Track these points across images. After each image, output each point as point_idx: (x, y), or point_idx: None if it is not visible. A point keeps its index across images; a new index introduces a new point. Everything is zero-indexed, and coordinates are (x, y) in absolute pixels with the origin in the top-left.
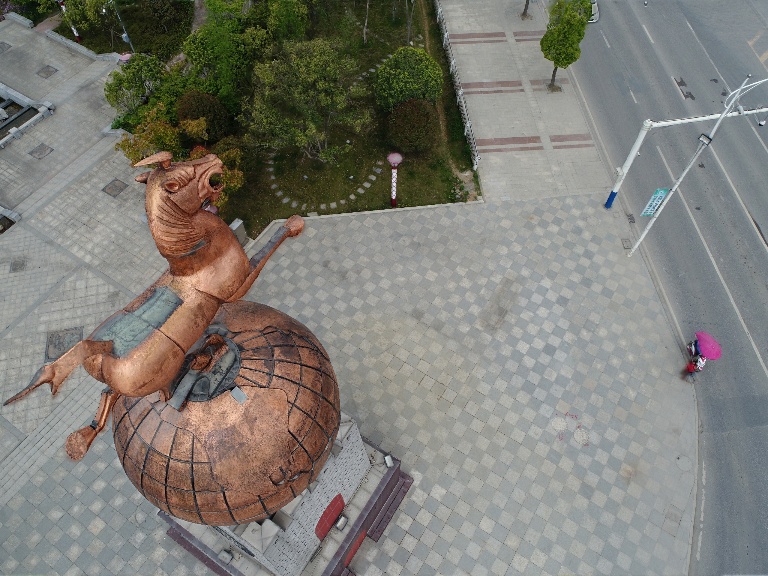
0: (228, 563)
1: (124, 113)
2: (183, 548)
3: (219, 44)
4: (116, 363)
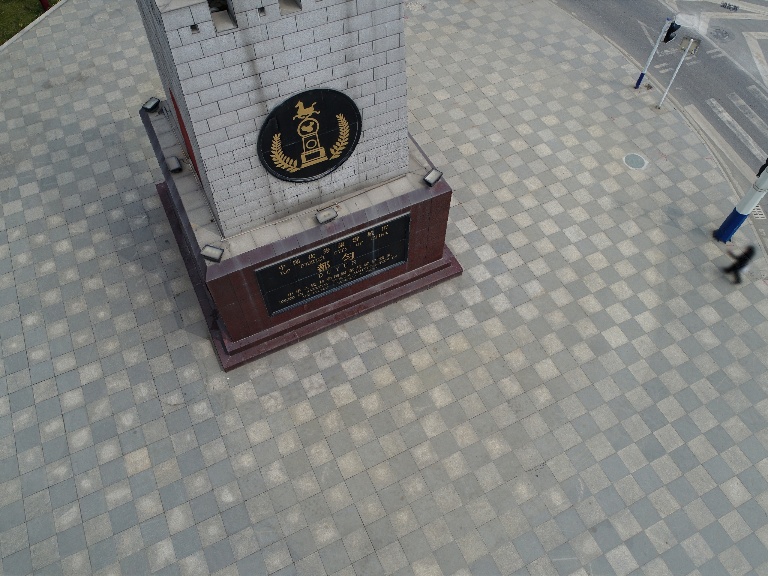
0: (336, 214)
1: None
2: (257, 361)
3: None
4: None
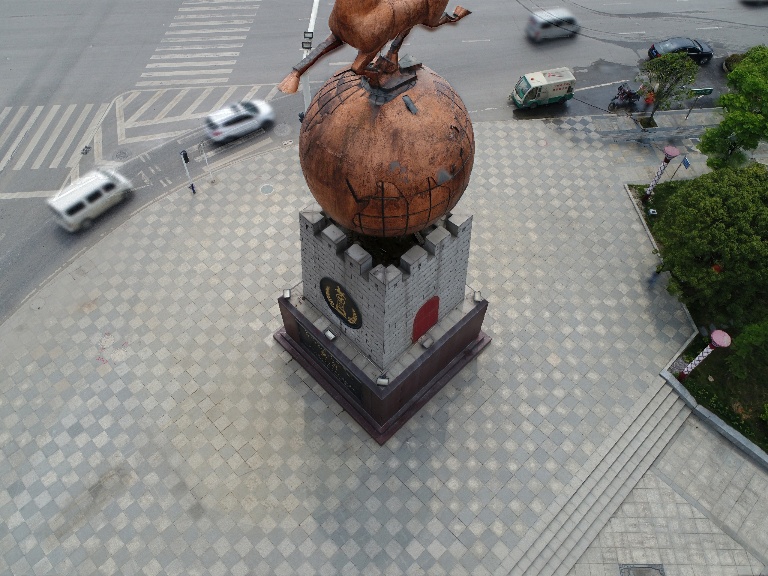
0: None
1: None
2: None
3: None
4: None
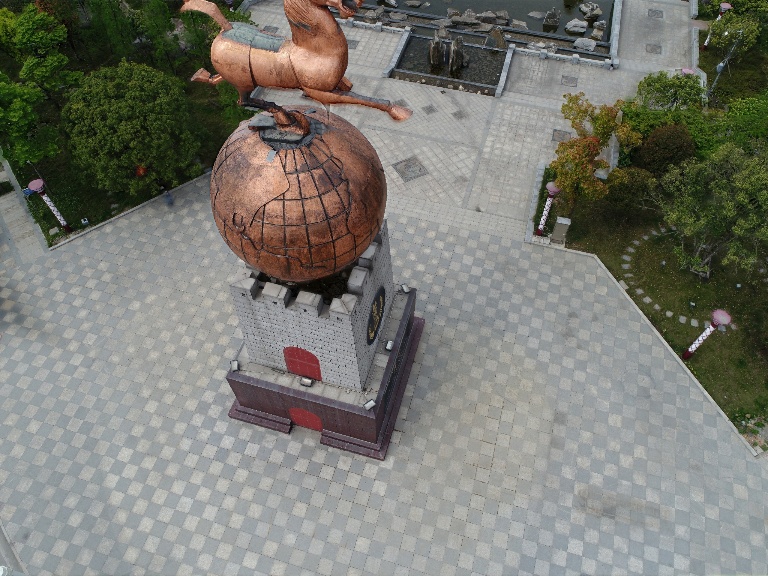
0: None
1: (639, 106)
2: None
3: (761, 123)
4: (219, 36)
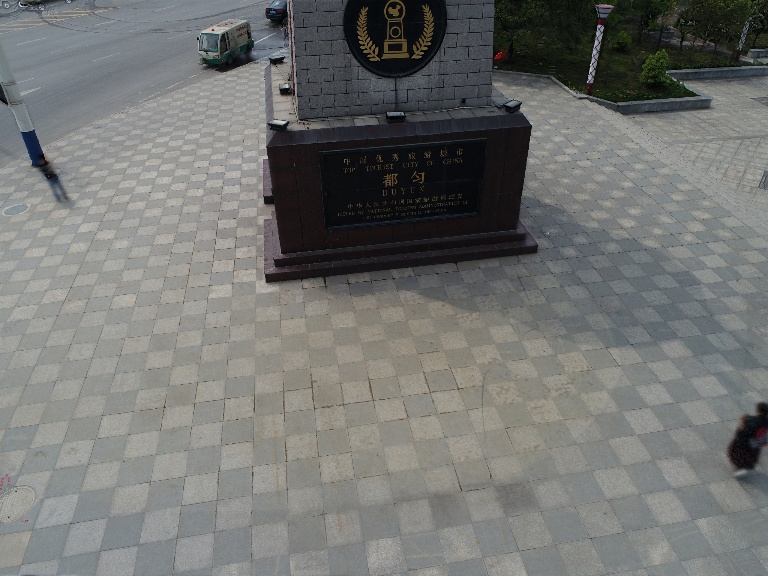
0: None
1: None
2: None
3: None
4: None
